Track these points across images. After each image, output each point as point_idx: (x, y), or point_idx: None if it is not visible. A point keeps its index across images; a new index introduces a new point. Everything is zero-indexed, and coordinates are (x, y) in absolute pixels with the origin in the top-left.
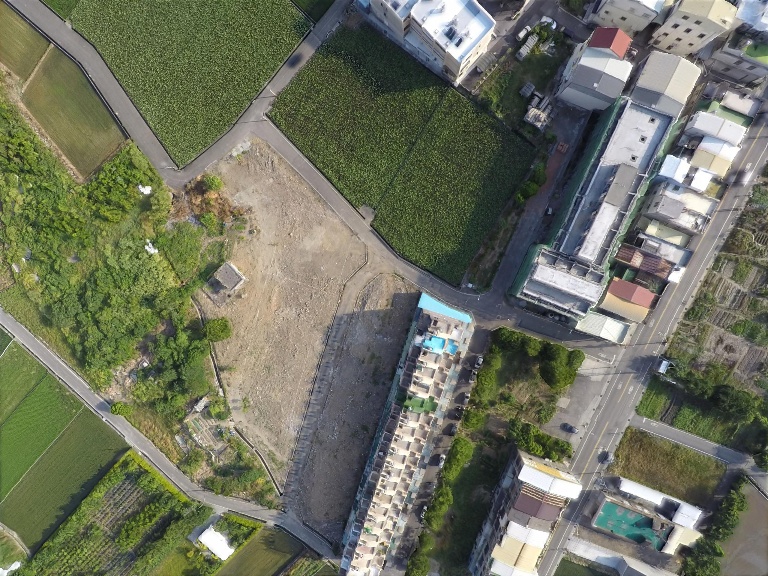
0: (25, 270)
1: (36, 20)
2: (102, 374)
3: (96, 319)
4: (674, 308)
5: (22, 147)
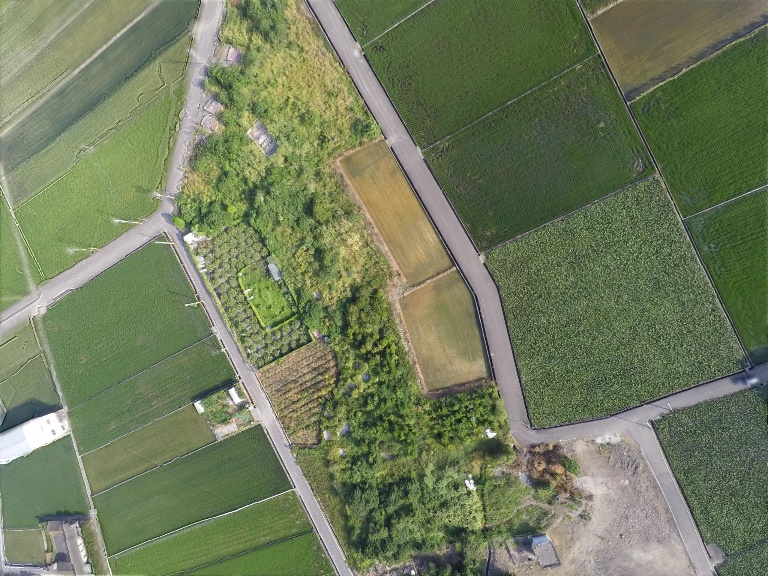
0: (335, 443)
1: (450, 242)
2: (368, 561)
3: (389, 520)
4: None
5: (388, 349)
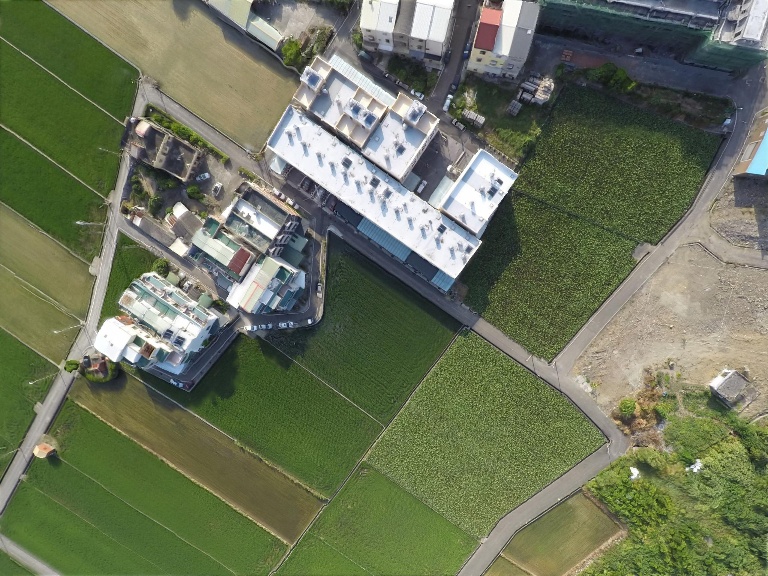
0: None
1: (483, 567)
2: None
3: None
4: None
5: None
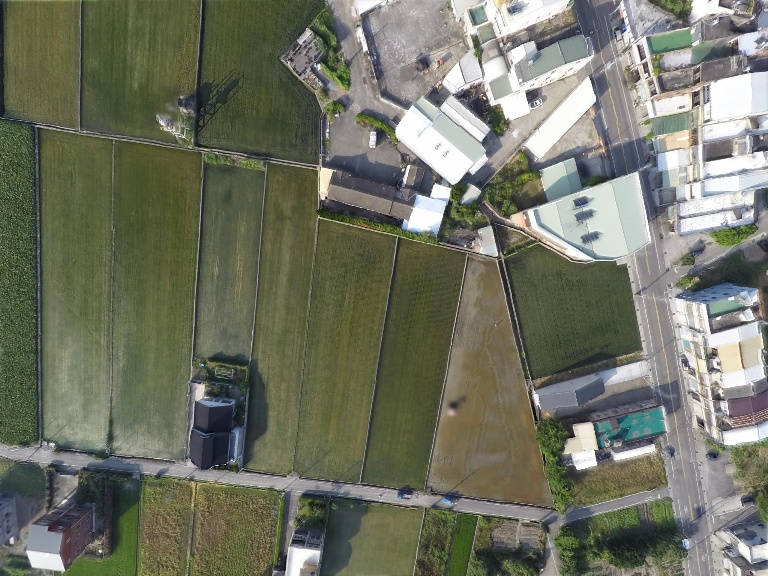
0: None
1: None
2: None
3: None
4: (694, 575)
5: None
